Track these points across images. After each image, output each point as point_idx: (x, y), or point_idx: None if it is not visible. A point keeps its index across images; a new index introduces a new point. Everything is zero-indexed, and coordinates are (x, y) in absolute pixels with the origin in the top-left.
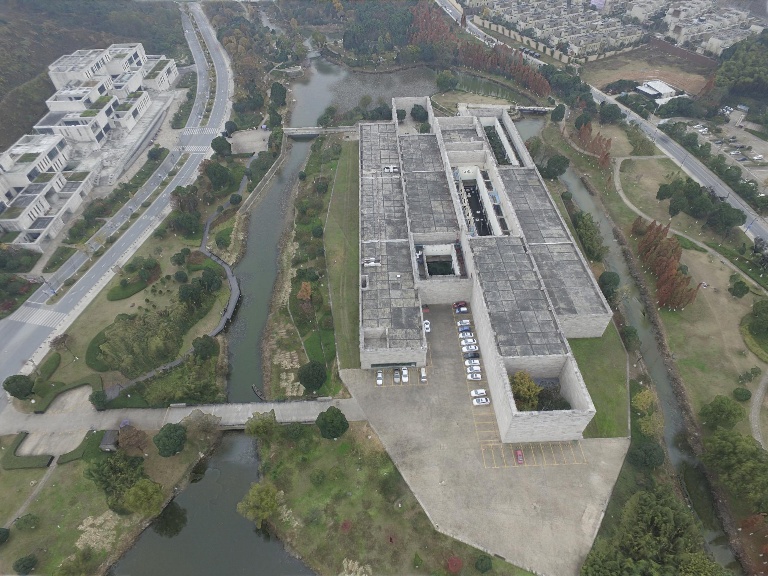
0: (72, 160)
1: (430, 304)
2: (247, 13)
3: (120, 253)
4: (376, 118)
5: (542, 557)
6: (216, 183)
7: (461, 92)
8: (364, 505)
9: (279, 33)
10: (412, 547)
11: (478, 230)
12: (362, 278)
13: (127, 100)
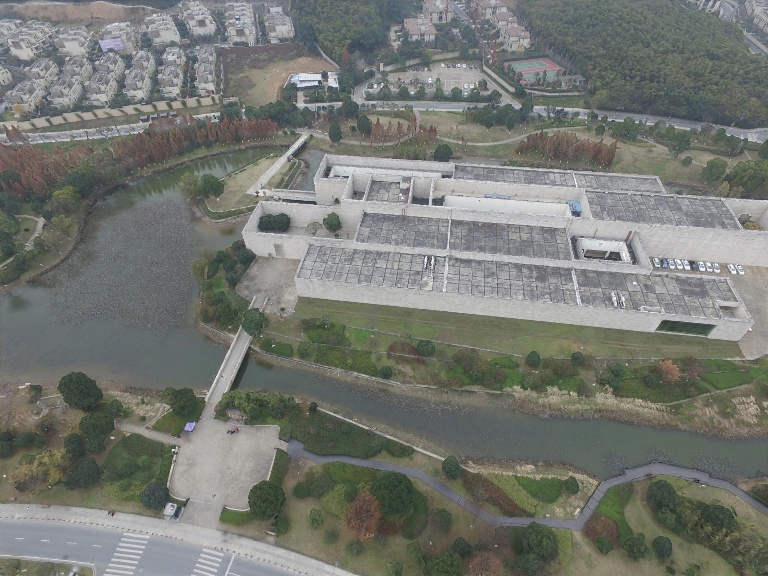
0: None
1: None
2: None
3: None
4: (244, 271)
5: None
6: None
7: None
8: None
9: None
10: None
11: None
12: None
13: None
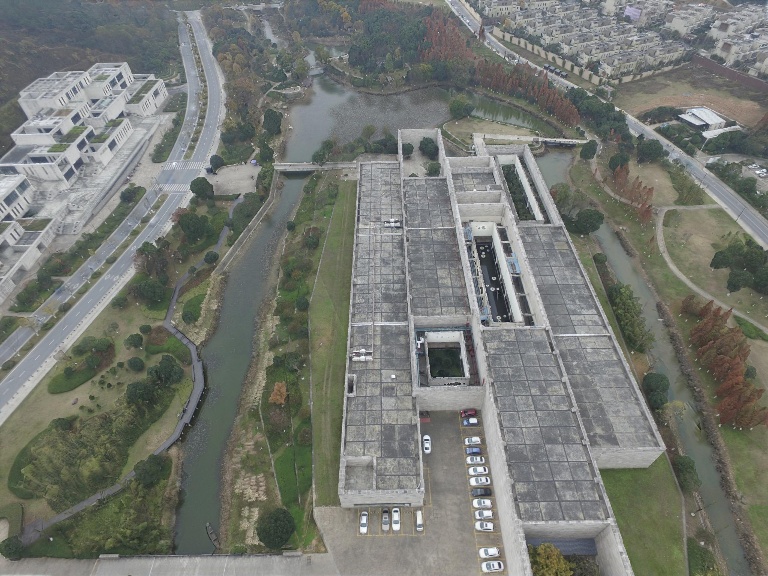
0: (35, 203)
1: (432, 410)
2: (249, 23)
3: (72, 326)
4: (380, 152)
5: None
6: (190, 237)
7: (477, 119)
8: None
9: (282, 45)
10: None
11: (493, 296)
12: (349, 378)
13: (105, 129)
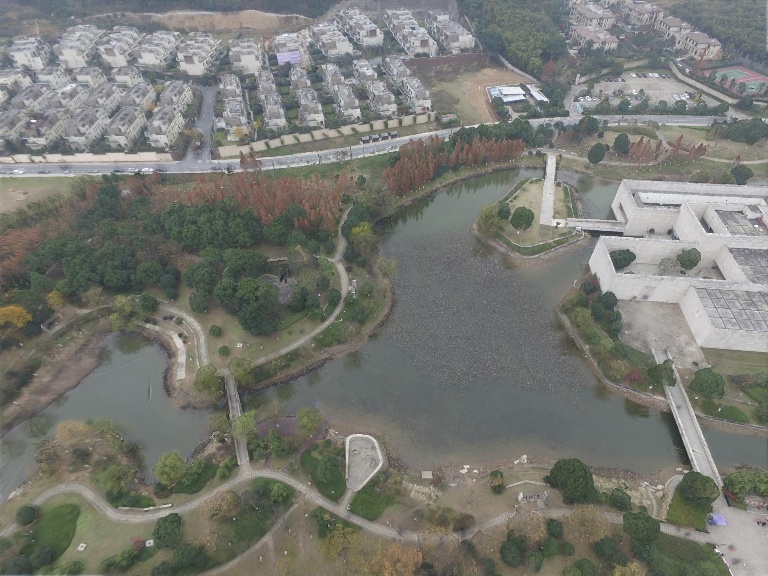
0: None
1: None
2: None
3: None
4: None
5: None
6: None
7: None
8: None
9: None
10: None
11: None
12: None
13: None
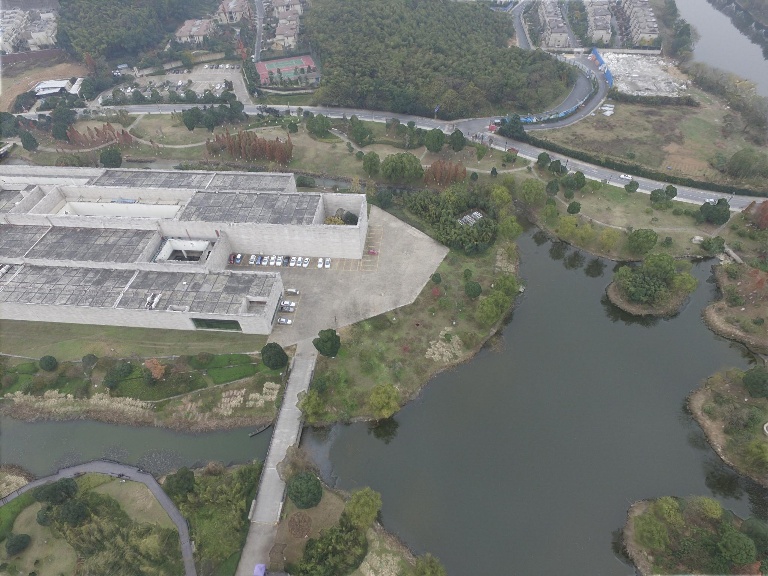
0: None
1: None
2: None
3: None
4: None
5: (433, 258)
6: None
7: None
8: (390, 342)
9: None
10: (422, 317)
11: None
12: None
13: None
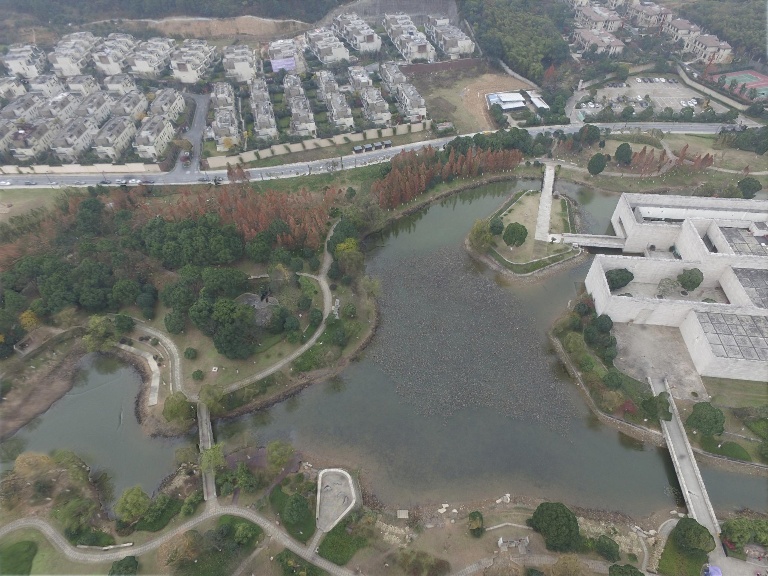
0: None
1: None
2: None
3: None
4: None
5: None
6: None
7: None
8: None
9: None
10: None
11: None
12: None
13: None
